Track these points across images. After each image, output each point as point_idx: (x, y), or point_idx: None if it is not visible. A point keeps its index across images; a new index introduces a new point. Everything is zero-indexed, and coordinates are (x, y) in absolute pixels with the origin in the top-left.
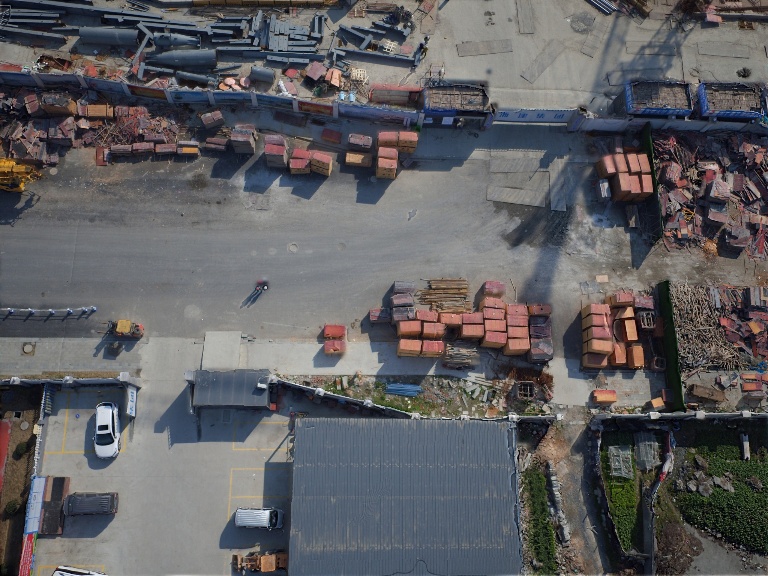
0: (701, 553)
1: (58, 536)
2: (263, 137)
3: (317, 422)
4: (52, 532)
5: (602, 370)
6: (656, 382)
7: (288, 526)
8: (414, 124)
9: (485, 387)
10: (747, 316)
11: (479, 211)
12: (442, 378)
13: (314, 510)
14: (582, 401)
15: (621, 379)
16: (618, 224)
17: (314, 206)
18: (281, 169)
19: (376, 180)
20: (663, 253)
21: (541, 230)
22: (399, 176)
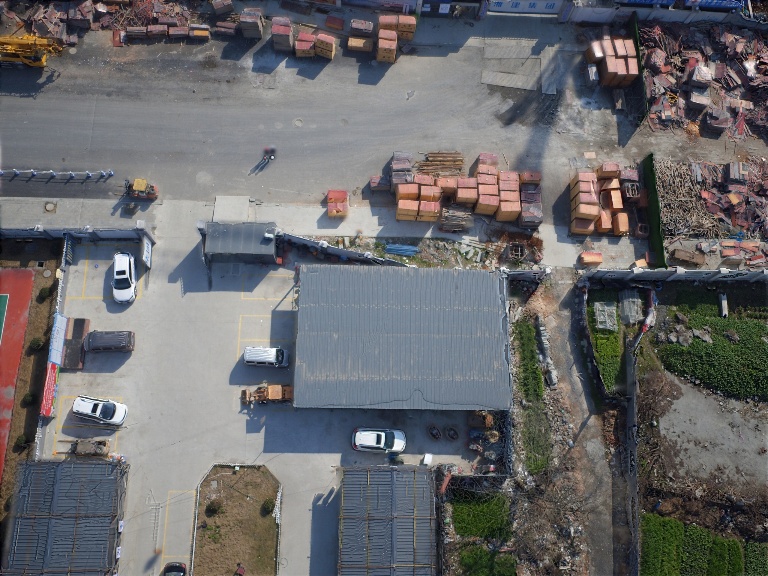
0: (681, 397)
1: (79, 371)
2: (270, 24)
3: (321, 268)
4: (73, 366)
5: (589, 236)
6: (640, 247)
7: (293, 365)
8: (413, 12)
9: (479, 249)
10: (727, 189)
11: (474, 93)
12: (438, 240)
13: (318, 345)
14: (570, 263)
15: (607, 244)
16: (605, 107)
17: (318, 86)
18: (287, 52)
19: (377, 64)
20: (648, 133)
21: (532, 111)
22: (398, 60)
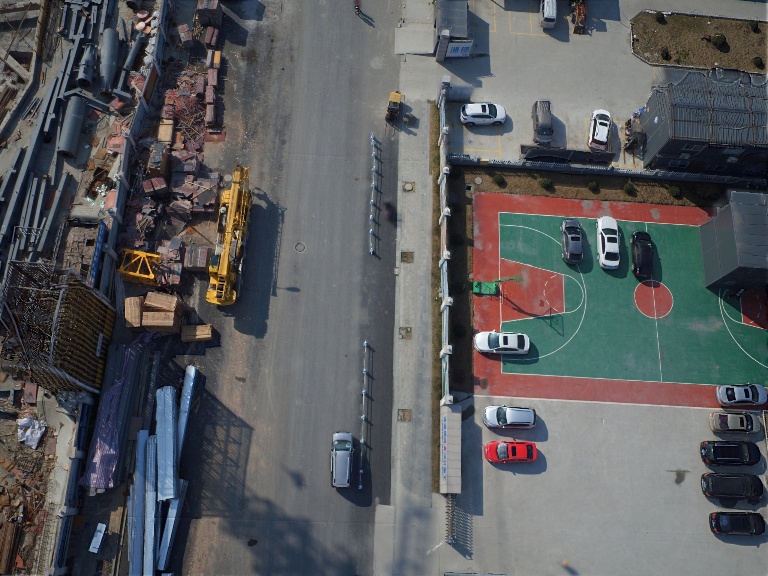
0: None
1: None
2: None
3: None
4: None
5: None
6: None
7: None
8: None
9: None
10: None
11: None
12: None
13: None
14: None
15: None
16: None
17: None
18: None
19: None
20: None
21: None
22: None
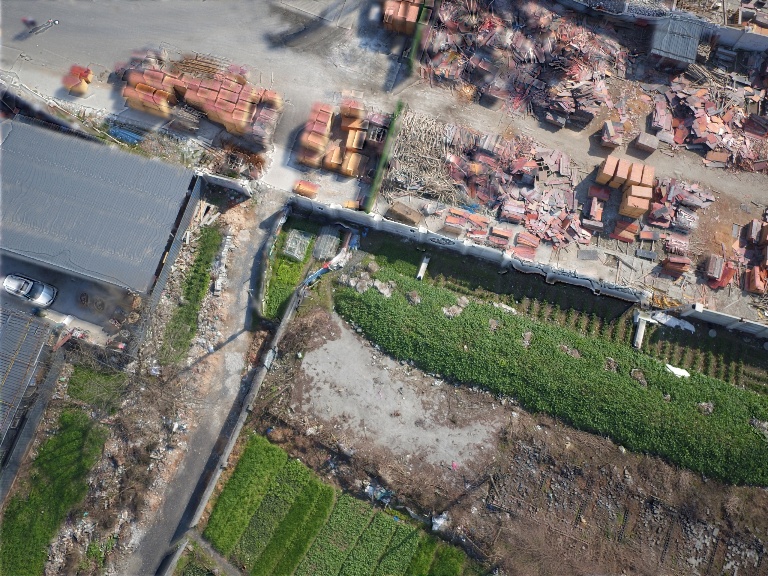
0: (337, 339)
1: None
2: None
3: (33, 121)
4: None
5: (321, 169)
6: (366, 192)
7: None
8: None
9: (208, 151)
10: (478, 159)
11: (270, 10)
12: (173, 133)
13: (1, 187)
14: (290, 187)
15: (335, 180)
16: (394, 53)
17: None
18: None
19: None
20: (426, 88)
21: (320, 40)
22: None
